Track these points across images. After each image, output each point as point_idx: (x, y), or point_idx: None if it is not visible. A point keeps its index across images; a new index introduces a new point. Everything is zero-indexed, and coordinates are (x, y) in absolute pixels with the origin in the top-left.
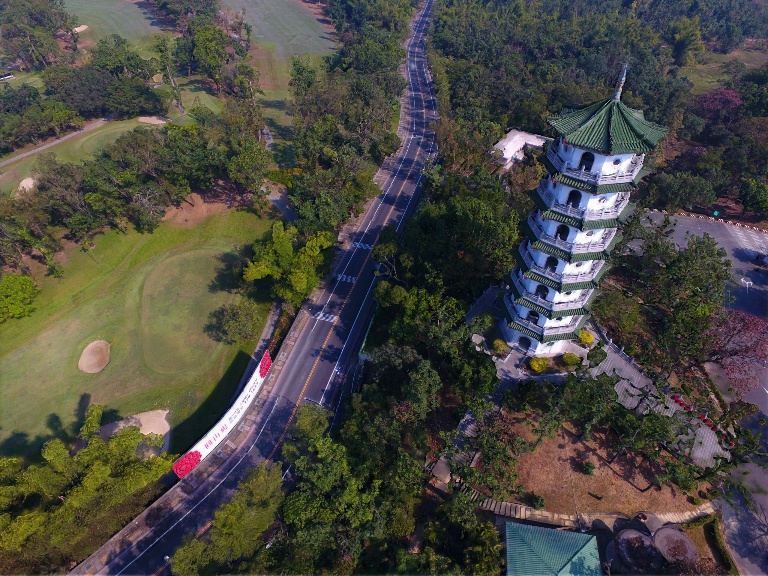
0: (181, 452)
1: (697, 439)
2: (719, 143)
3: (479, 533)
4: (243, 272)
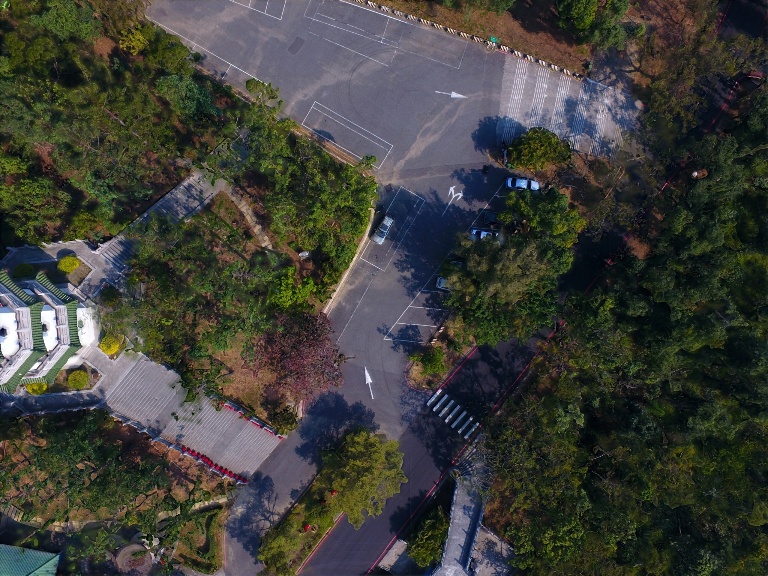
0: None
1: (235, 441)
2: None
3: None
4: None
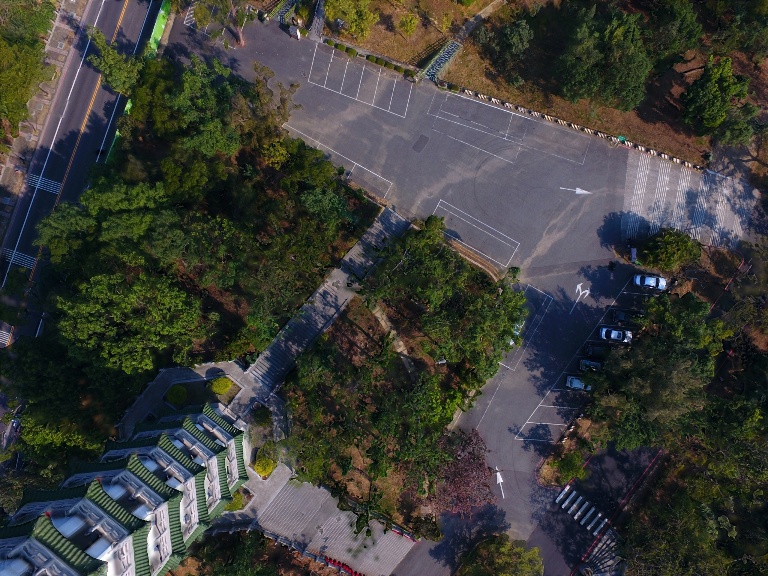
0: None
1: (373, 548)
2: None
3: None
4: None
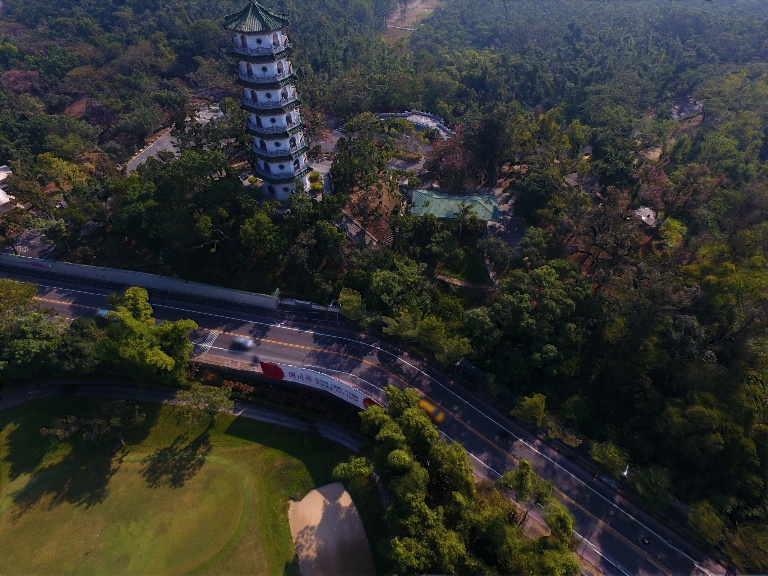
0: (345, 457)
1: None
2: (65, 106)
3: (420, 221)
4: (162, 368)
